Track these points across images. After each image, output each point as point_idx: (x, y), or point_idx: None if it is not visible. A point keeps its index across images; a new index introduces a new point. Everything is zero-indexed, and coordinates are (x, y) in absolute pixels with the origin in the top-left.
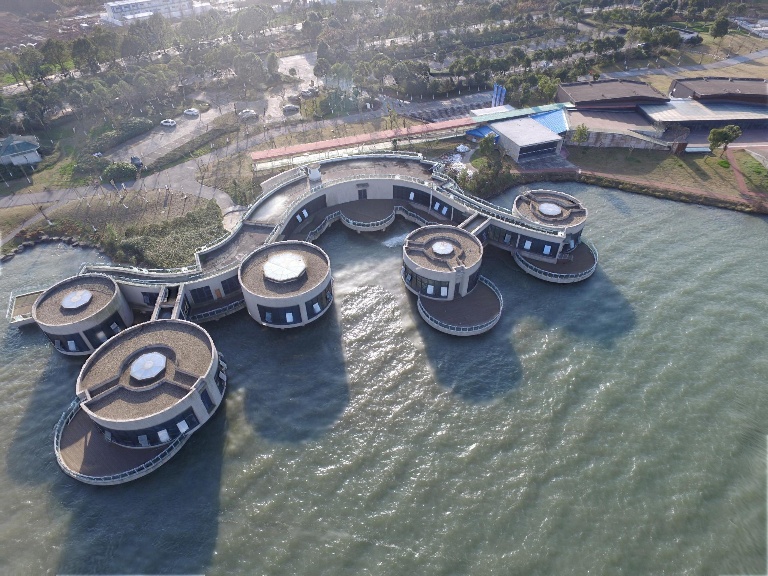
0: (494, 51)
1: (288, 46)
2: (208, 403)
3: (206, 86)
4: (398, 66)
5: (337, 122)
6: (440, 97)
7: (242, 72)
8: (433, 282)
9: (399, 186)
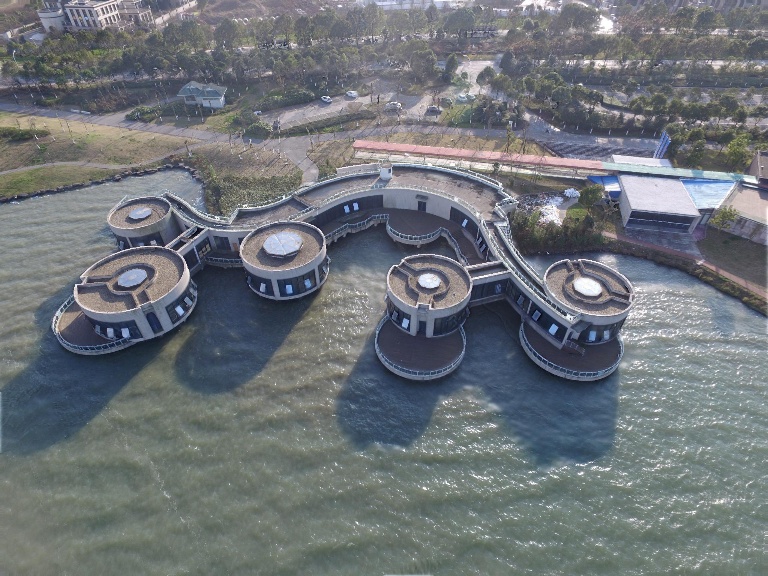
0: (709, 95)
1: (487, 50)
2: (158, 325)
3: (383, 74)
4: (559, 89)
5: (467, 132)
6: (600, 133)
7: (416, 67)
8: (397, 309)
9: (456, 209)
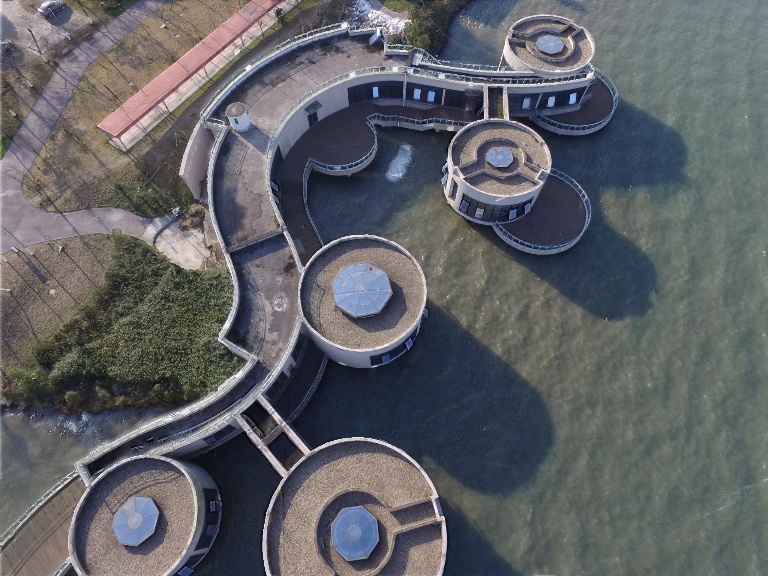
0: None
1: None
2: None
3: None
4: None
5: (150, 6)
6: None
7: None
8: (517, 205)
9: (356, 86)
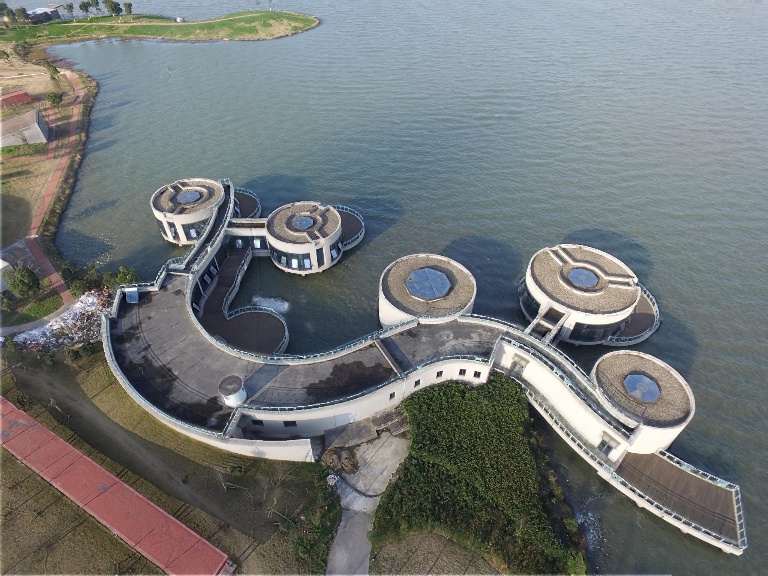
0: None
1: None
2: None
3: None
4: None
5: None
6: None
7: None
8: None
9: None
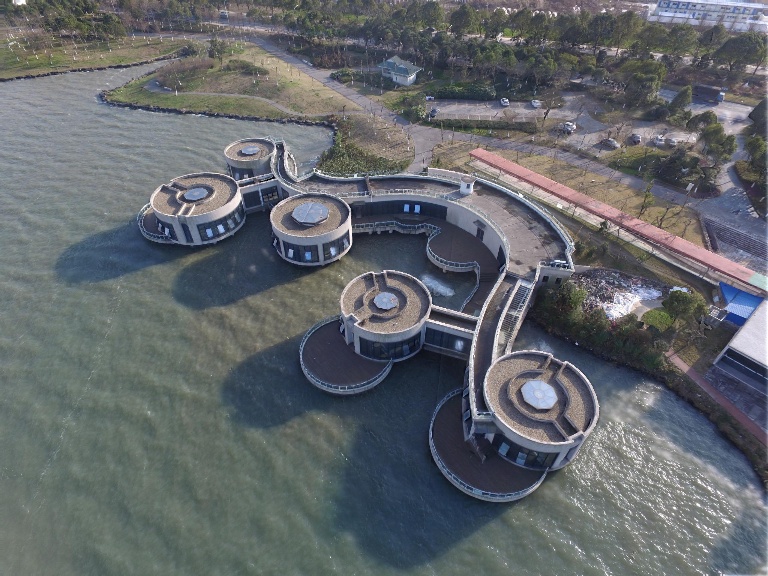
0: None
1: (761, 94)
2: (191, 237)
3: (593, 91)
4: None
5: (622, 179)
6: None
7: (630, 92)
8: None
9: (502, 250)
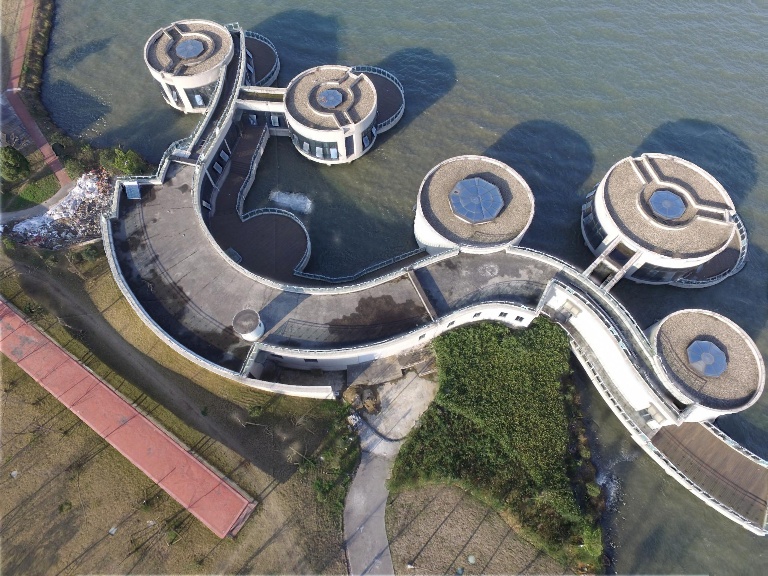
0: None
1: None
2: None
3: None
4: None
5: None
6: None
7: None
8: None
9: None
